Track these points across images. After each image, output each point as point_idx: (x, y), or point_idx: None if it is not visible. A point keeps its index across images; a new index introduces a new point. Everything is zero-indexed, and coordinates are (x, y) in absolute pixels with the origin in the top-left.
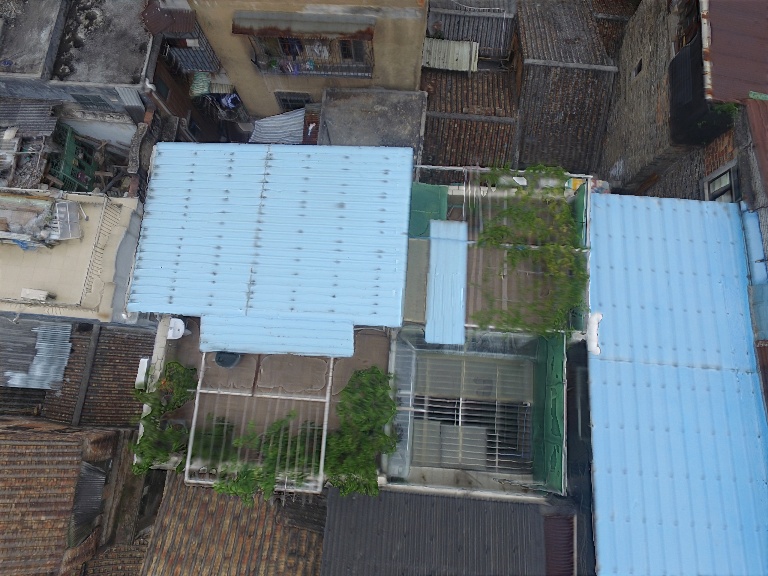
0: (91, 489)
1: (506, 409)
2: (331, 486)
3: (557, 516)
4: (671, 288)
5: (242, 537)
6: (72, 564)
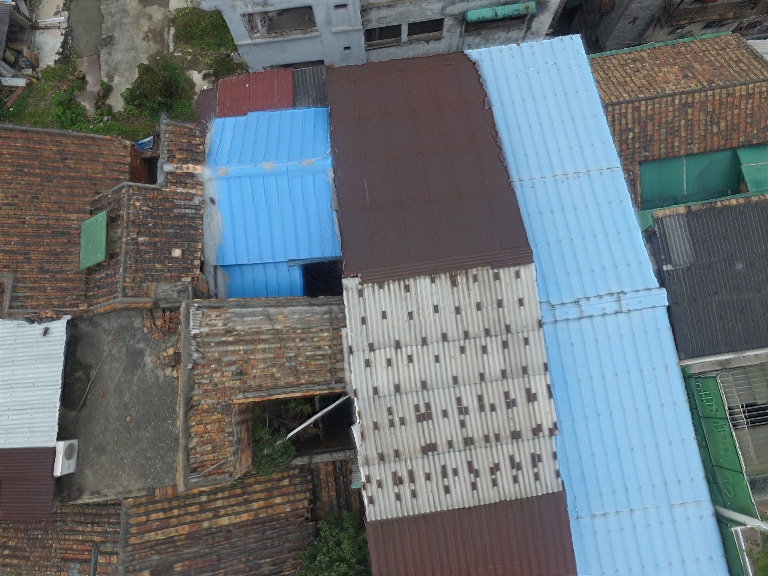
0: None
1: None
2: None
3: None
4: None
5: None
6: None
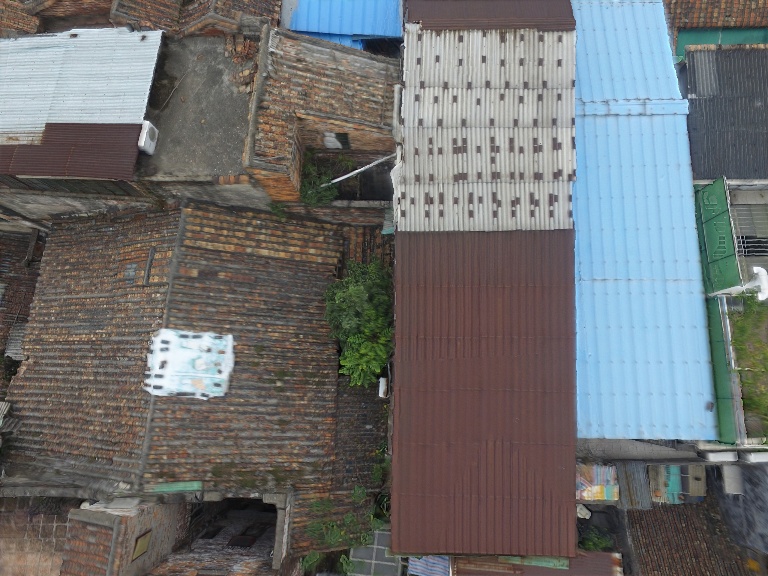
0: None
1: None
2: None
3: None
4: (634, 347)
5: None
6: None
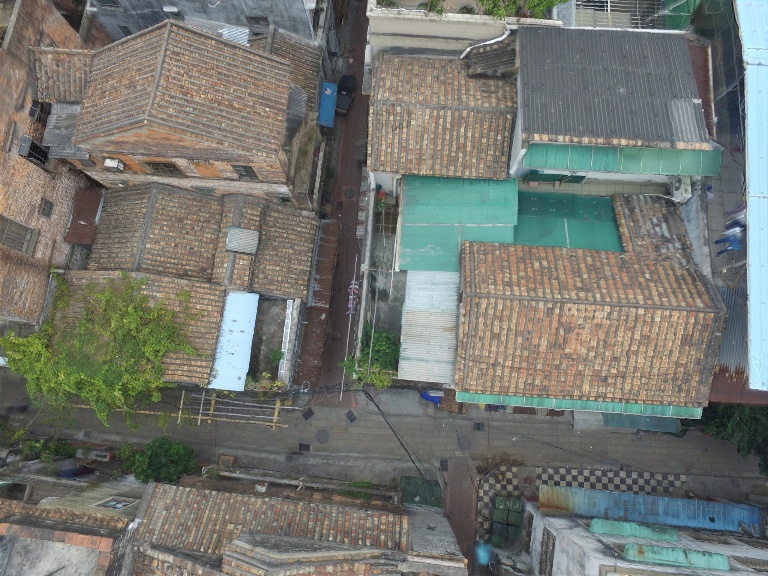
0: (297, 102)
1: (645, 1)
2: (520, 27)
3: (697, 41)
4: None
5: (443, 84)
6: (280, 165)
